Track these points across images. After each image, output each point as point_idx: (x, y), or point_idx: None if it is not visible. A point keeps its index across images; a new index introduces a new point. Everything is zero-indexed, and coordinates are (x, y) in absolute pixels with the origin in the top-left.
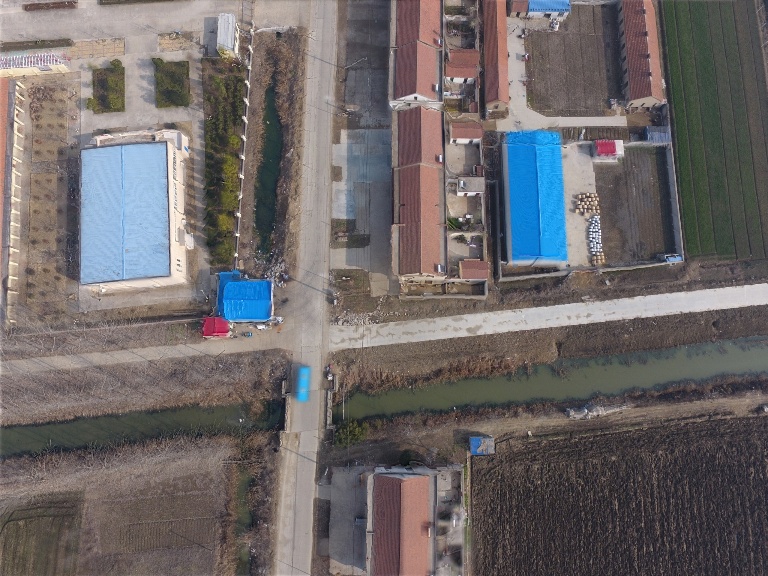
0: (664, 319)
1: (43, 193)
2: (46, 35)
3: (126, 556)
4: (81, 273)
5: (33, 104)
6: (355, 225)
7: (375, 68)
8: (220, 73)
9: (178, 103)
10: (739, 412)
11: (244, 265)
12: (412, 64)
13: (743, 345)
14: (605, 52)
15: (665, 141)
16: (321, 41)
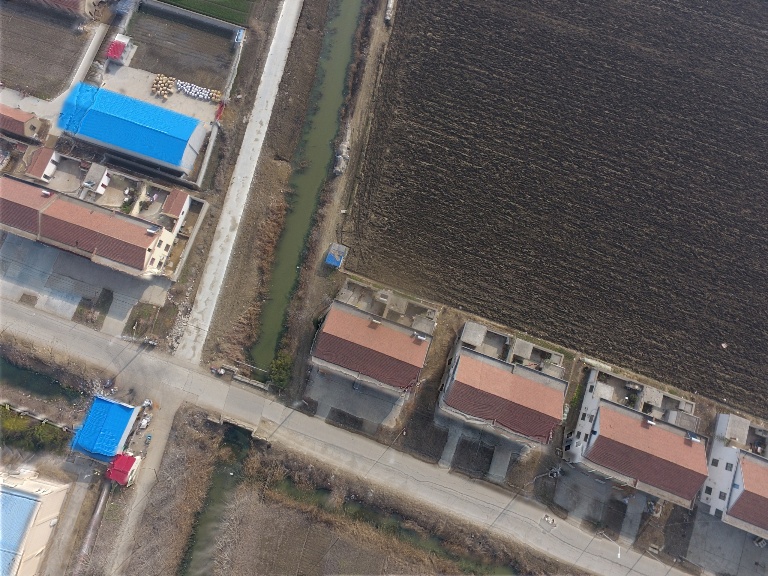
0: (289, 64)
1: None
2: None
3: None
4: None
5: None
6: (87, 300)
7: None
8: None
9: None
10: (384, 39)
11: (79, 424)
12: None
13: (334, 14)
14: (33, 16)
15: (136, 0)
16: None
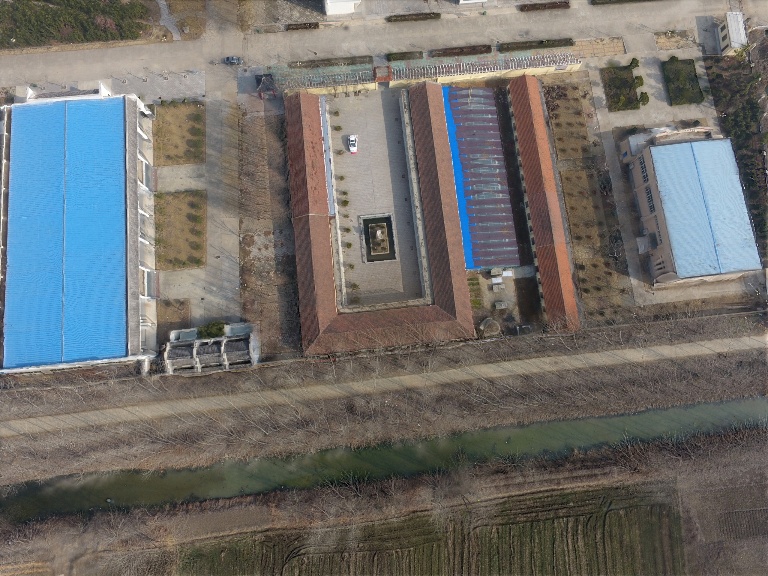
0: None
1: (576, 190)
2: (545, 35)
3: (729, 543)
4: (676, 267)
5: (550, 103)
6: None
7: None
8: (723, 71)
9: (692, 100)
10: None
11: None
12: None
13: None
14: None
15: None
16: None
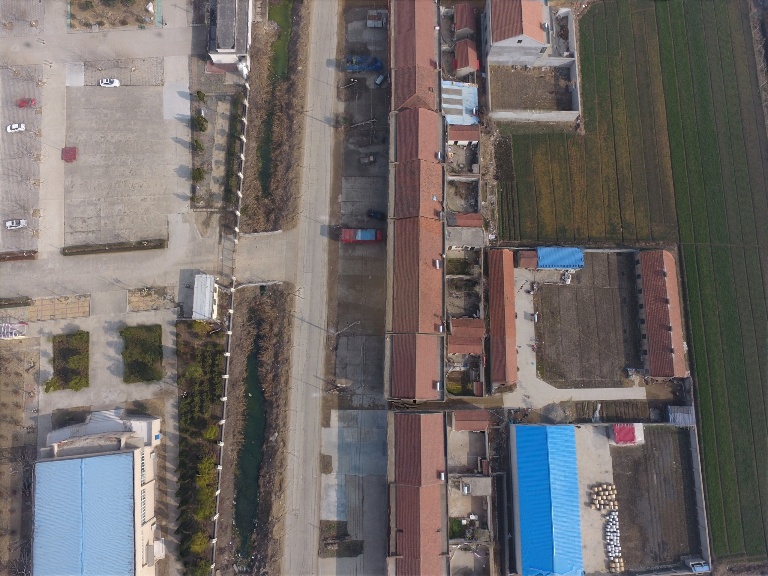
0: None
1: None
2: (1, 292)
3: None
4: None
5: None
6: (346, 529)
7: (369, 334)
8: (197, 338)
9: (149, 378)
10: None
11: None
12: (410, 360)
13: None
14: (621, 309)
15: (689, 423)
16: (309, 300)
